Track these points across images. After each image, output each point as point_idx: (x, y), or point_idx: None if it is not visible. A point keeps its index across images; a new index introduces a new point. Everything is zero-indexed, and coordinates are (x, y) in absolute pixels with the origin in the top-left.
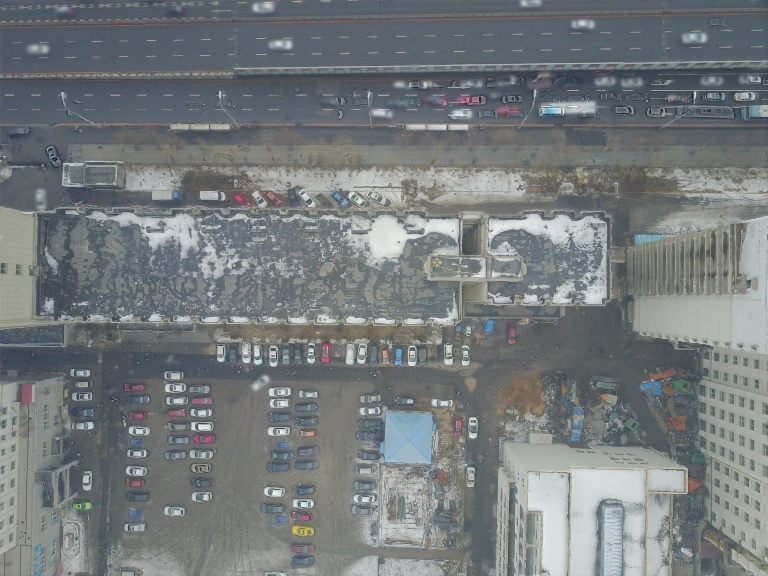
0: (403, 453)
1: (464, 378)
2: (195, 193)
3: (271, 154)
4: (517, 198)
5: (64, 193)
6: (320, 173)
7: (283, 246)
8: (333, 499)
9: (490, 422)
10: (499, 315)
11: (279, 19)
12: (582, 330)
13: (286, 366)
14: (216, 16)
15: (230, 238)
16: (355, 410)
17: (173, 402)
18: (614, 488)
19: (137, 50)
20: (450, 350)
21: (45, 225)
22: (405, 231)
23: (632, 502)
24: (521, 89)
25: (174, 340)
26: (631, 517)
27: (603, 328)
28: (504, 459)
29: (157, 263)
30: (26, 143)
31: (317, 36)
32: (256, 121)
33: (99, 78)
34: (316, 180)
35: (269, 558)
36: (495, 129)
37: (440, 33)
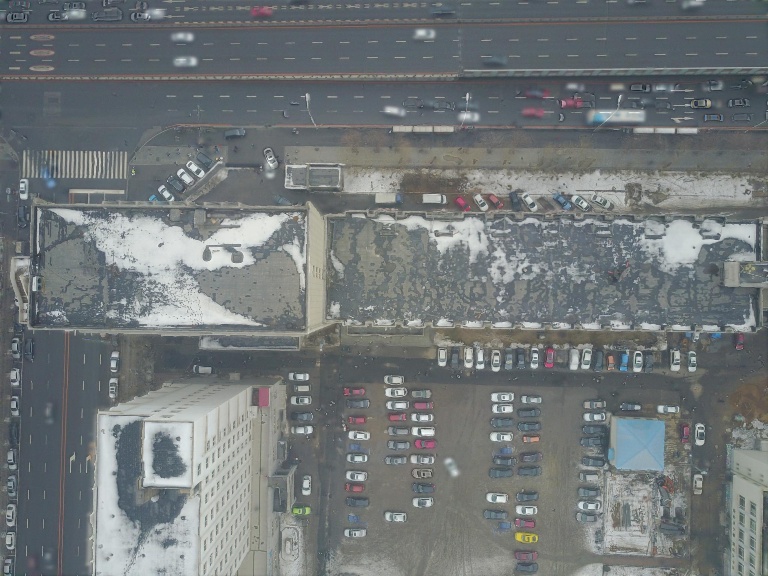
0: (637, 460)
1: (689, 384)
2: (414, 196)
3: (491, 157)
4: (743, 203)
5: (282, 195)
6: (547, 176)
7: (574, 251)
8: (556, 506)
9: (716, 429)
10: None
11: (505, 21)
12: None
13: (508, 371)
14: (440, 17)
15: (520, 242)
16: (578, 416)
17: (395, 407)
18: None
19: (358, 51)
20: (678, 356)
21: (331, 228)
22: (700, 236)
23: None
24: (748, 92)
25: (393, 344)
26: None
27: None
28: (734, 467)
29: (445, 267)
30: (241, 145)
31: (544, 38)
32: (476, 123)
33: (317, 79)
34: (538, 183)
35: (491, 565)
36: (720, 133)
37: (672, 36)
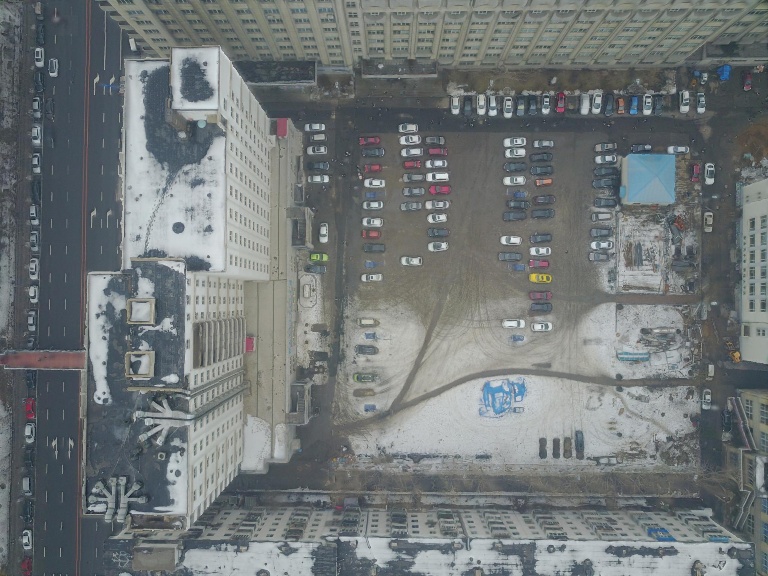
0: (648, 191)
1: (698, 126)
2: None
3: None
4: None
5: None
6: None
7: None
8: (569, 248)
9: (726, 169)
10: (740, 56)
11: None
12: None
13: (520, 118)
14: None
15: None
16: (589, 160)
17: (410, 153)
18: None
19: None
20: (687, 95)
21: None
22: None
23: None
24: None
25: (407, 95)
26: None
27: None
28: (744, 201)
29: None
30: None
31: None
32: None
33: None
34: None
35: (506, 307)
36: None
37: None
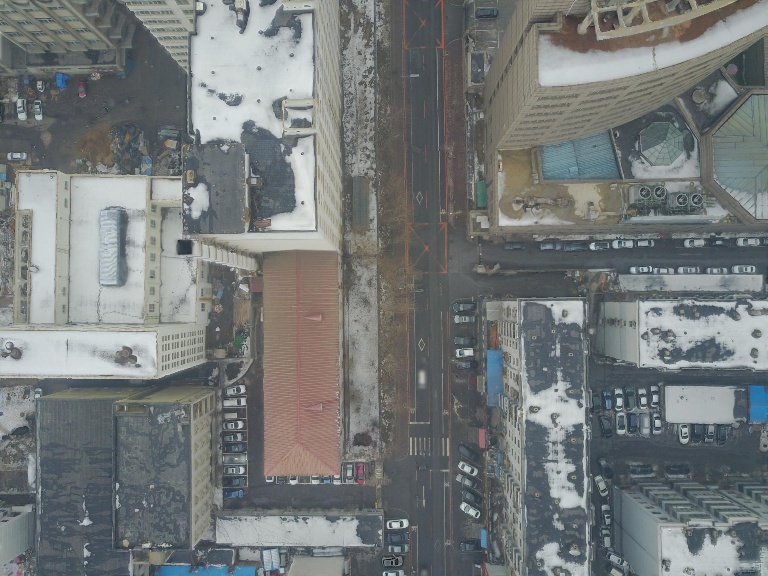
0: None
1: (40, 133)
2: None
3: None
4: None
5: None
6: None
7: None
8: None
9: None
10: (59, 64)
11: None
12: (152, 84)
13: None
14: None
15: None
16: None
17: None
18: (118, 196)
19: None
20: (20, 103)
21: None
22: None
23: (135, 209)
24: None
25: None
26: (134, 223)
27: (170, 80)
28: None
29: None
30: None
31: None
32: None
33: None
34: None
35: None
36: None
37: None
